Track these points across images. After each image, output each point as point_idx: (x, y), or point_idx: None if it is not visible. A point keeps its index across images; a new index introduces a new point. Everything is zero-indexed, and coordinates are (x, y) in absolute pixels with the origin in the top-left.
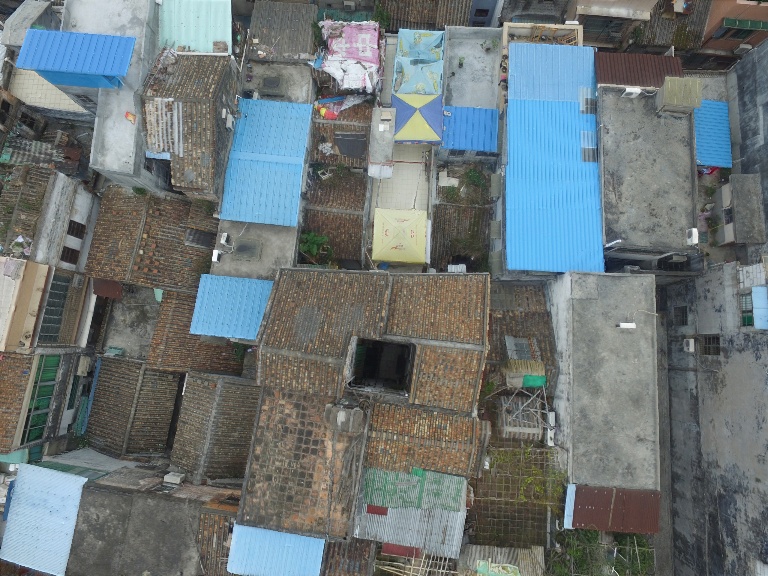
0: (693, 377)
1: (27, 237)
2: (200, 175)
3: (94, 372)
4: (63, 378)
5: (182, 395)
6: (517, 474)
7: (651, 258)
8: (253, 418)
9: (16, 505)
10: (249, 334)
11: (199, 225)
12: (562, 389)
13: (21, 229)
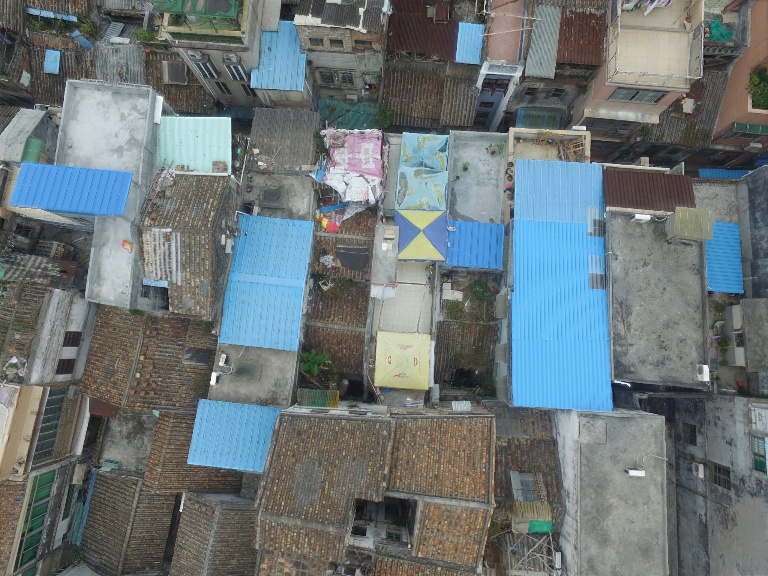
0: (702, 503)
1: (21, 357)
2: (198, 303)
3: (90, 479)
4: (58, 491)
5: (179, 502)
6: None
7: None
8: (252, 543)
9: None
10: (248, 465)
11: (197, 343)
12: (569, 532)
13: (15, 349)
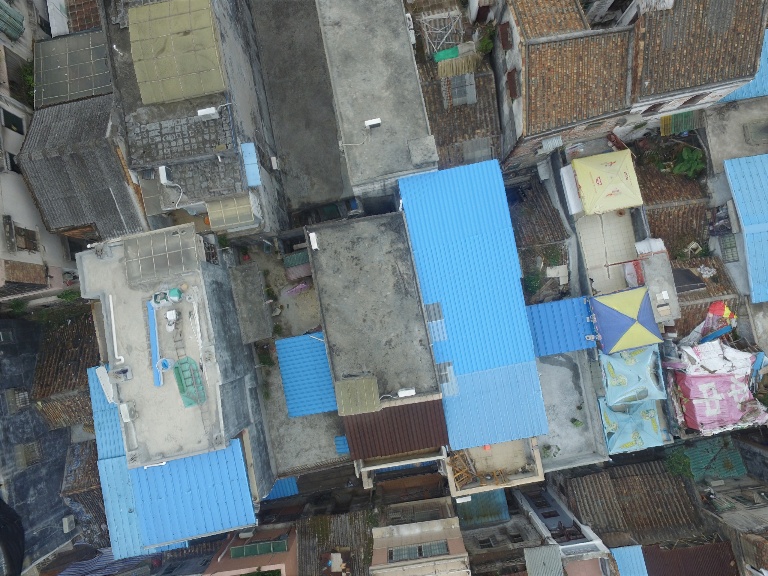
0: None
1: None
2: None
3: None
4: None
5: None
6: None
7: None
8: None
9: None
10: None
11: None
12: None
13: None
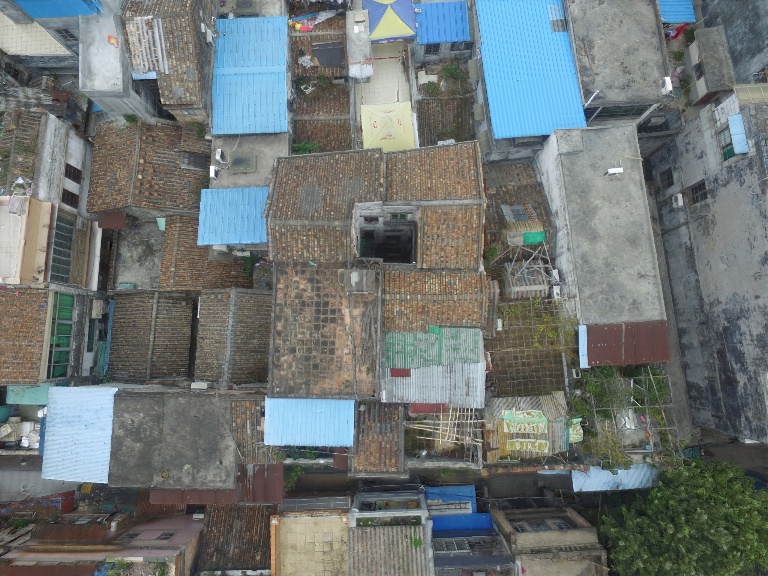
0: (685, 230)
1: (27, 178)
2: (188, 90)
3: (108, 314)
4: (79, 319)
5: (197, 326)
6: (529, 324)
7: None
8: (269, 325)
9: (51, 426)
10: (255, 238)
11: (192, 147)
12: (562, 244)
13: (20, 171)
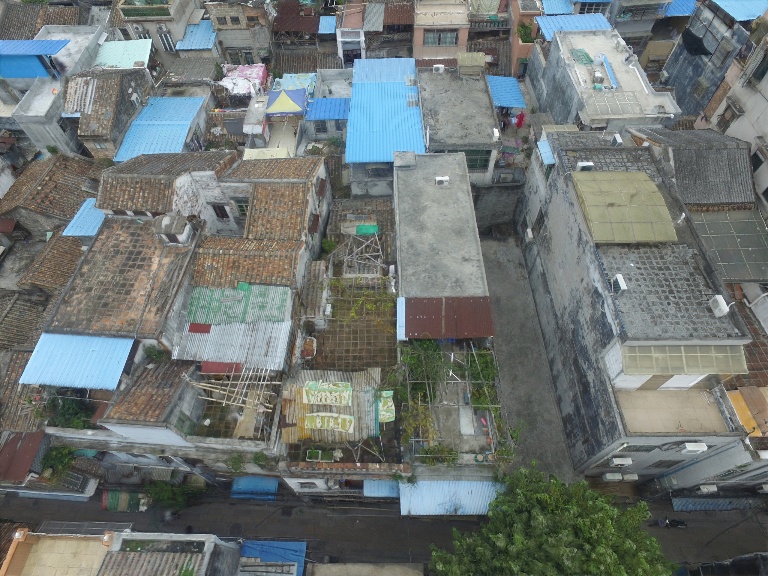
0: (538, 260)
1: None
2: (102, 125)
3: None
4: None
5: None
6: (348, 296)
7: (485, 181)
8: None
9: None
10: None
11: (98, 176)
12: None
13: None
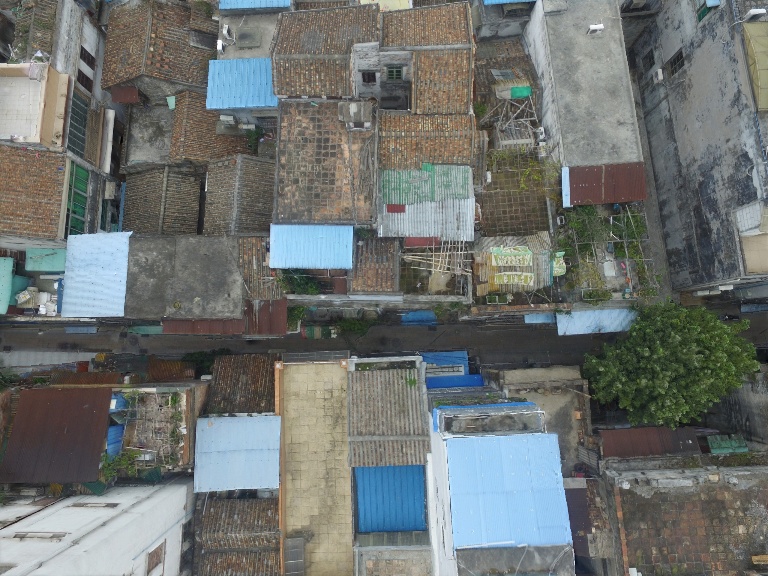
0: (665, 104)
1: (45, 52)
2: None
3: (120, 196)
4: (93, 195)
5: (204, 208)
6: (516, 168)
7: None
8: None
9: (70, 270)
10: (260, 102)
11: (201, 26)
12: (547, 101)
13: (39, 45)
